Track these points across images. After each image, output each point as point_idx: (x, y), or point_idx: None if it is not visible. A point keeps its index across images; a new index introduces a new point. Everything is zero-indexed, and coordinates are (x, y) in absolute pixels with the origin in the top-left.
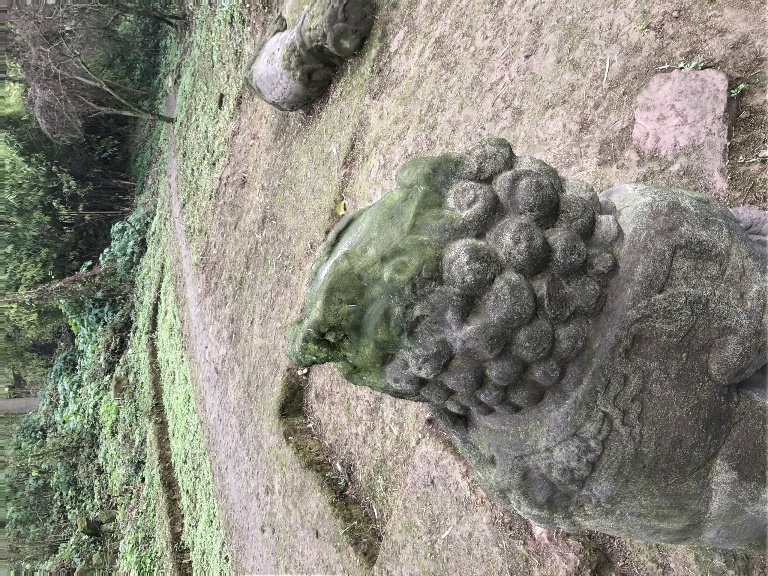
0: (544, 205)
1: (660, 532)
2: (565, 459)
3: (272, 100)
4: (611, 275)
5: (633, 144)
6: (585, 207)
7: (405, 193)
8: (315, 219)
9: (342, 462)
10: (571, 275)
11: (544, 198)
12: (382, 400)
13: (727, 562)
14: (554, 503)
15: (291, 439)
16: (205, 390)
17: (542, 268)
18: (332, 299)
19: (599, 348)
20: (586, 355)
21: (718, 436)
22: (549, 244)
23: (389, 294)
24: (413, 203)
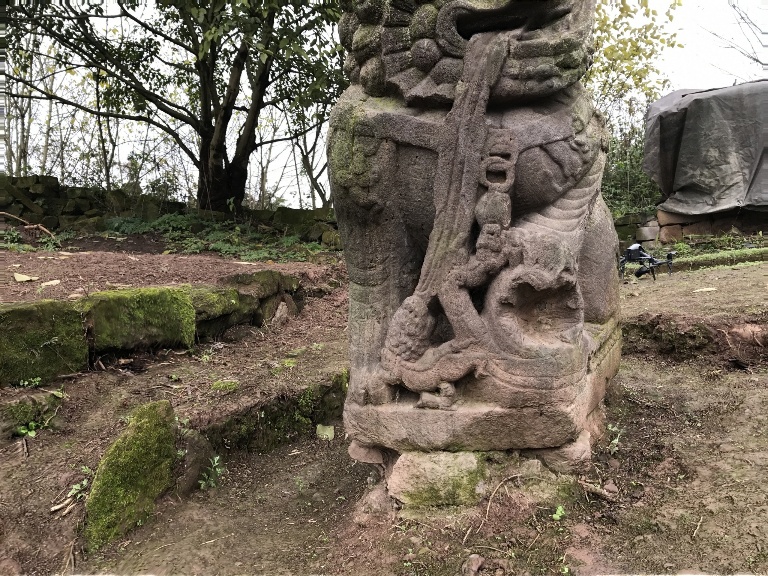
0: None
1: None
2: None
3: None
4: None
5: None
6: None
7: None
8: None
9: None
10: None
11: None
12: None
13: None
14: None
15: None
16: None
17: None
18: None
19: None
20: None
21: None
22: None
23: None
24: None
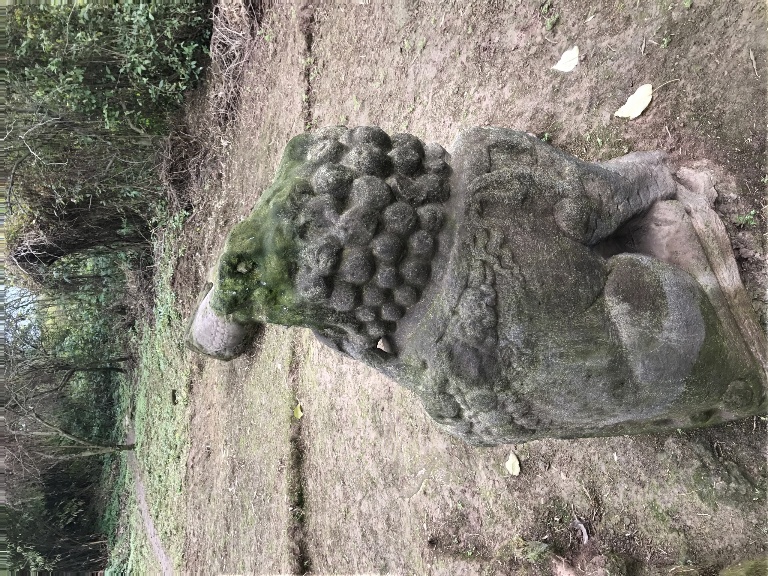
0: (376, 137)
1: (591, 374)
2: (469, 311)
3: (214, 350)
4: (448, 173)
5: None
6: (409, 136)
7: (279, 174)
8: (278, 436)
9: None
10: (414, 175)
11: (375, 133)
12: (387, 567)
13: (723, 478)
14: (487, 373)
15: None
16: None
17: (389, 172)
18: (236, 240)
19: (456, 216)
20: (449, 224)
21: (596, 278)
22: None
23: (277, 214)
24: None
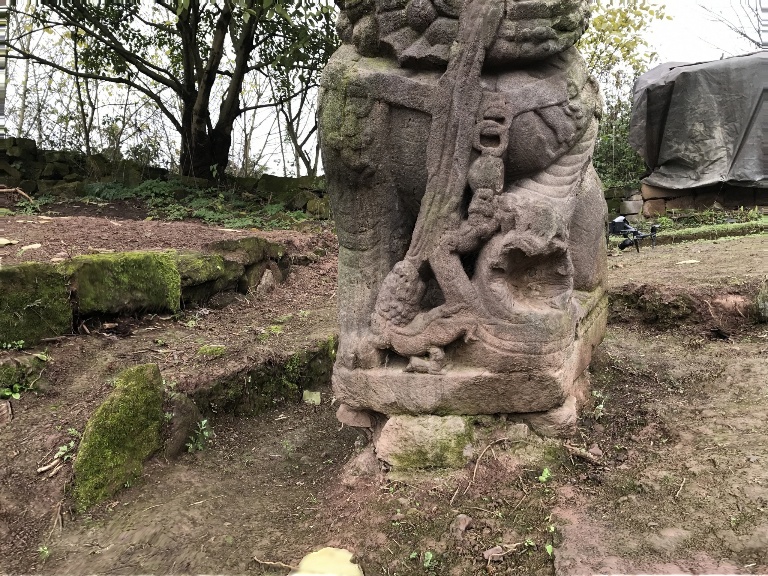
0: None
1: None
2: None
3: None
4: None
5: None
6: None
7: None
8: None
9: None
10: None
11: None
12: None
13: None
14: None
15: None
16: None
17: None
18: None
19: None
20: None
21: None
22: None
23: None
24: None
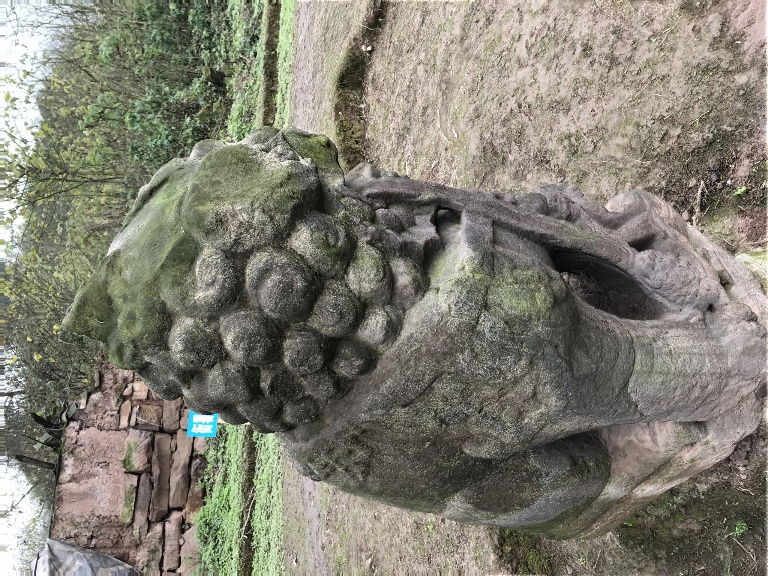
0: (286, 311)
1: None
2: None
3: None
4: None
5: (727, 6)
6: (341, 317)
7: (176, 219)
8: None
9: (372, 162)
10: None
11: (287, 305)
12: (409, 132)
13: None
14: None
15: (340, 115)
16: (301, 3)
17: None
18: (85, 309)
19: (327, 427)
20: (316, 425)
21: (461, 484)
22: (282, 348)
23: None
24: (171, 244)
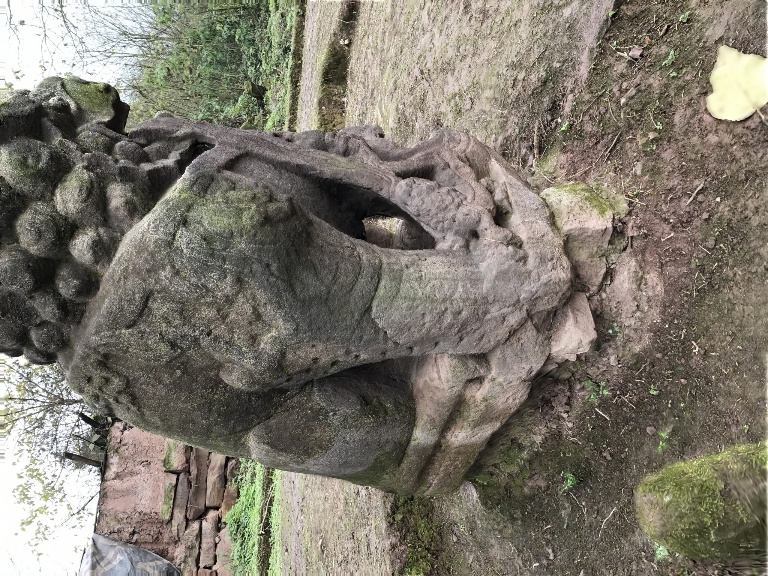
0: None
1: None
2: None
3: None
4: None
5: None
6: (40, 235)
7: None
8: None
9: None
10: None
11: None
12: (366, 116)
13: None
14: None
15: (323, 109)
16: (309, 9)
17: None
18: None
19: None
20: (67, 352)
21: (246, 421)
22: None
23: None
24: None
